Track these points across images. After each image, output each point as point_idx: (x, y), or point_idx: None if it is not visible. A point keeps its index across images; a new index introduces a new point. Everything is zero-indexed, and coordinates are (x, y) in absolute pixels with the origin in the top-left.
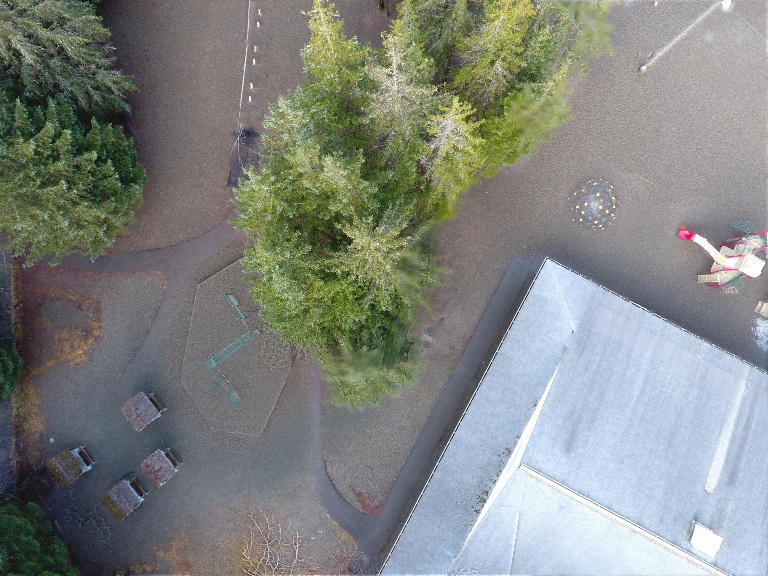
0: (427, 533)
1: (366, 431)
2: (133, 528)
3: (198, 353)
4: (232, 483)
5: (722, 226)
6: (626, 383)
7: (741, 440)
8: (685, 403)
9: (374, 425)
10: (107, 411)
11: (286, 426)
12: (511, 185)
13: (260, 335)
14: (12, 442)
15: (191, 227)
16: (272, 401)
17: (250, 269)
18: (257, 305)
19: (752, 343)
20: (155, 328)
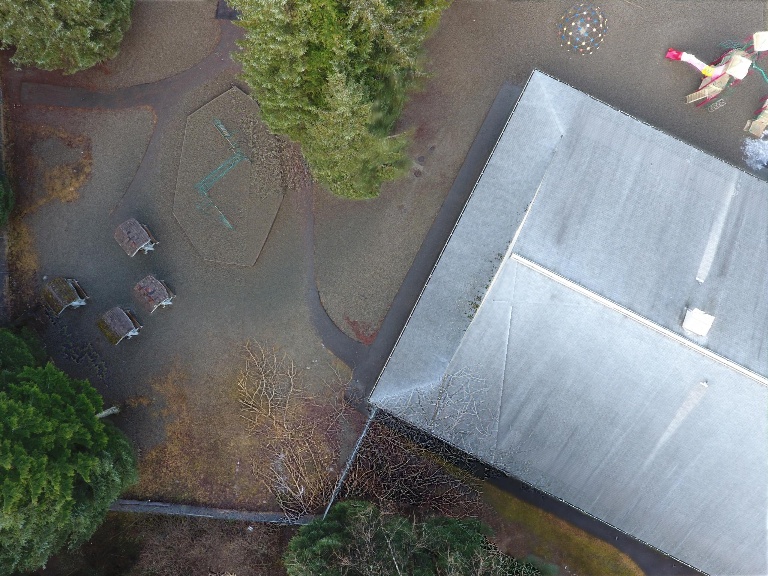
0: (421, 343)
1: (359, 261)
2: (128, 362)
3: (189, 185)
4: (226, 314)
5: (709, 47)
6: (616, 183)
7: (731, 236)
8: (675, 202)
9: (367, 254)
10: (100, 247)
11: (279, 257)
12: (498, 12)
13: (251, 165)
14: (5, 279)
15: (180, 61)
16: (264, 230)
17: (240, 99)
18: (247, 135)
19: (741, 162)
20: (146, 162)
